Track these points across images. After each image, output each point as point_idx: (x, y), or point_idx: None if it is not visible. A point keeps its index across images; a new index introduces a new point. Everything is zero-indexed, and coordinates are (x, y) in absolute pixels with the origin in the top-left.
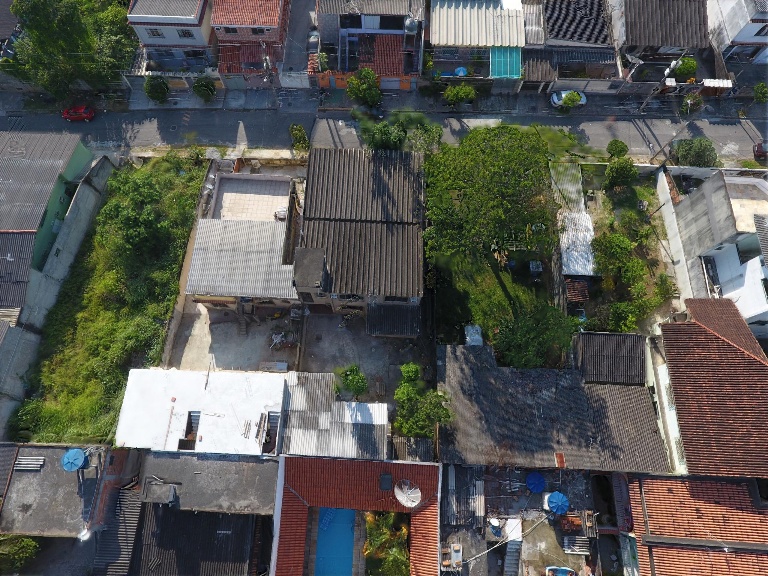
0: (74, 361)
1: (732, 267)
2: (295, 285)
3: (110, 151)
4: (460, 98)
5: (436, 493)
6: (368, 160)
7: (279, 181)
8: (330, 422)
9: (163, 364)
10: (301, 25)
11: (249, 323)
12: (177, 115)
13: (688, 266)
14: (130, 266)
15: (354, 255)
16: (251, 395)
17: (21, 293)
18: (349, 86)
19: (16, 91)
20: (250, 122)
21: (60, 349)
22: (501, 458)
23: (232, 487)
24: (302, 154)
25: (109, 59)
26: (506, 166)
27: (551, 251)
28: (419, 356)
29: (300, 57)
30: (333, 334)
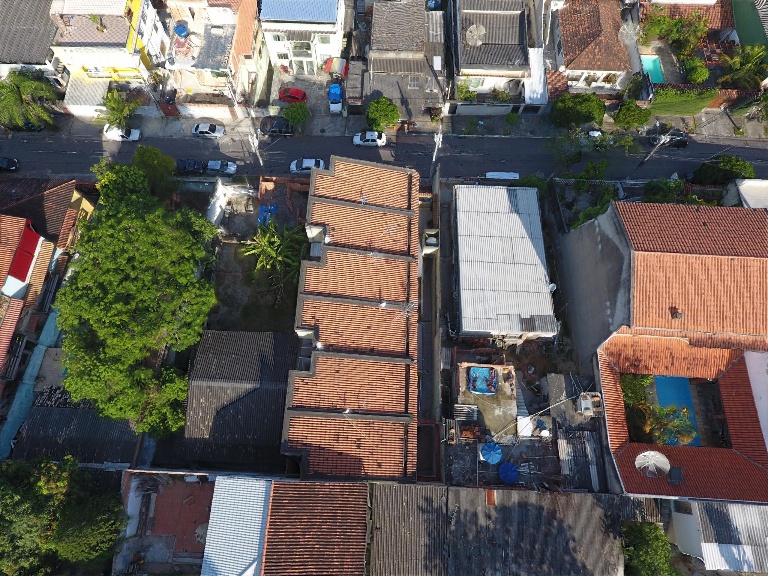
0: None
1: None
2: None
3: None
4: None
5: None
6: None
7: None
8: (767, 546)
9: None
10: None
11: None
12: None
13: None
14: None
15: None
16: None
17: None
18: None
19: None
20: None
21: None
22: None
23: None
24: None
25: None
26: None
27: None
28: None
29: None
30: None
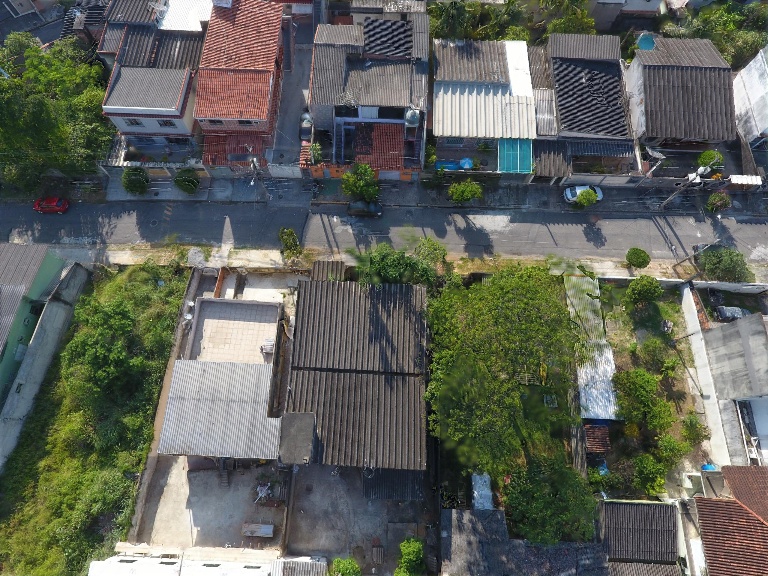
0: (34, 523)
1: None
2: (280, 461)
3: (84, 249)
4: (466, 198)
5: None
6: (364, 296)
7: (266, 305)
8: None
9: (134, 527)
10: (293, 105)
11: (231, 472)
12: (158, 208)
13: (720, 406)
14: (99, 407)
15: (348, 415)
16: None
17: None
18: (345, 182)
19: None
20: (237, 217)
21: (19, 507)
22: None
23: None
24: (293, 258)
25: (83, 150)
26: (523, 344)
27: None
28: (421, 511)
29: (292, 143)
30: (325, 484)
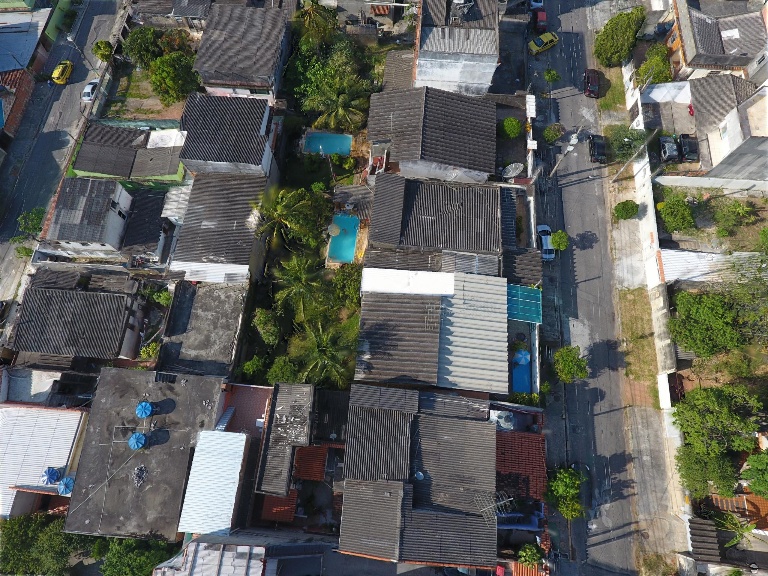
0: None
1: None
2: None
3: None
4: None
5: None
6: None
7: None
8: None
9: None
10: None
11: None
12: None
13: None
14: None
15: None
16: None
17: None
18: None
19: None
20: None
21: None
22: None
23: None
24: None
25: None
26: None
27: None
28: None
29: None
30: None
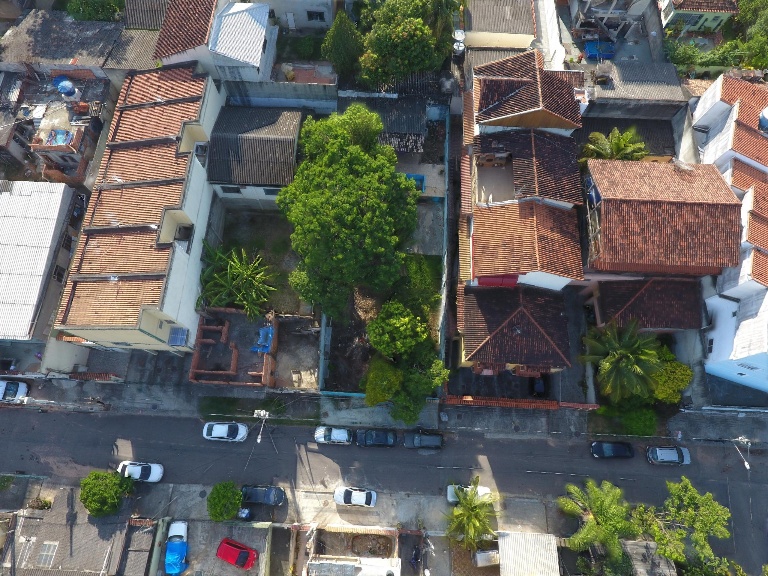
0: None
1: None
2: None
3: None
4: None
5: None
6: None
7: None
8: None
9: None
10: None
11: None
12: None
13: None
14: None
15: None
16: None
17: None
18: None
19: None
20: None
21: None
22: (27, 57)
23: None
24: None
25: None
26: None
27: None
28: None
29: None
30: None
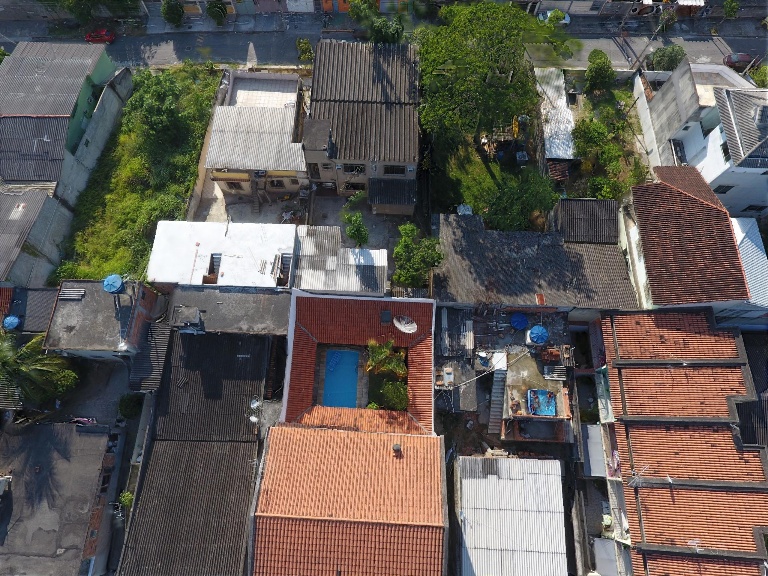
0: (104, 232)
1: (697, 143)
2: (304, 148)
3: None
4: (453, 14)
5: (430, 328)
6: (369, 51)
7: (288, 80)
8: (336, 264)
9: None
10: None
11: (261, 203)
12: (191, 37)
13: (660, 152)
14: (153, 153)
15: (357, 129)
16: (266, 240)
17: (57, 169)
18: (351, 6)
19: (41, 19)
20: (259, 42)
21: (91, 223)
22: (488, 296)
23: (250, 314)
24: (308, 67)
25: None
26: (491, 31)
27: (536, 143)
28: (416, 231)
29: None
30: (338, 213)
